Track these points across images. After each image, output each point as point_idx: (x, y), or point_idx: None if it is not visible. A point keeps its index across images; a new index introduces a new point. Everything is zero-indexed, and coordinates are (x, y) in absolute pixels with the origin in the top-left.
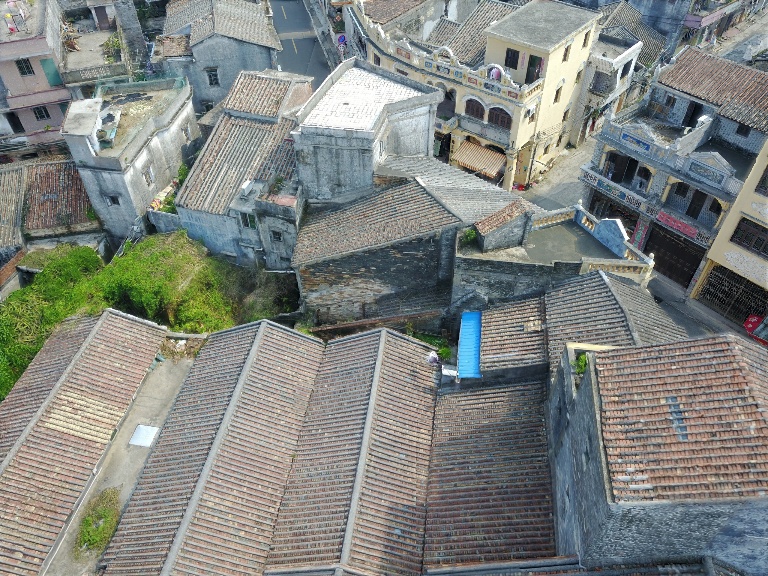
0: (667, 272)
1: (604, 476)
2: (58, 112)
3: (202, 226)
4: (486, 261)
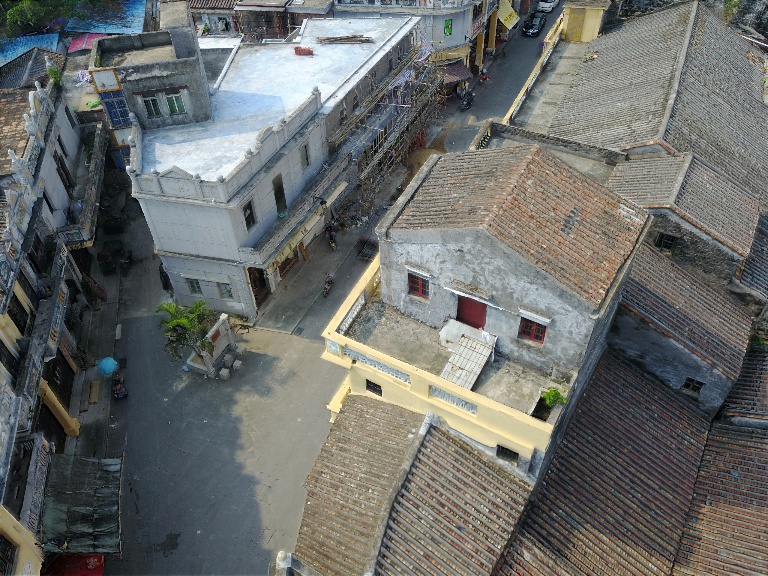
0: None
1: None
2: None
3: None
4: None
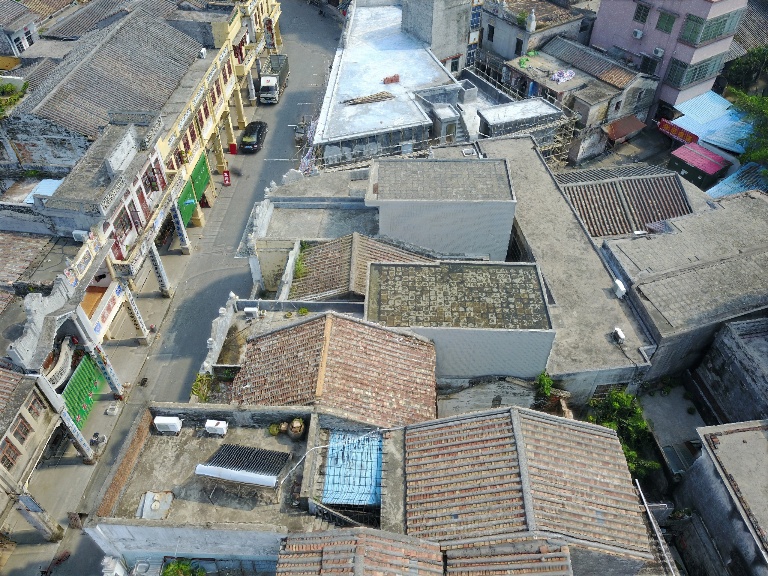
0: (336, 5)
1: None
2: None
3: None
4: None
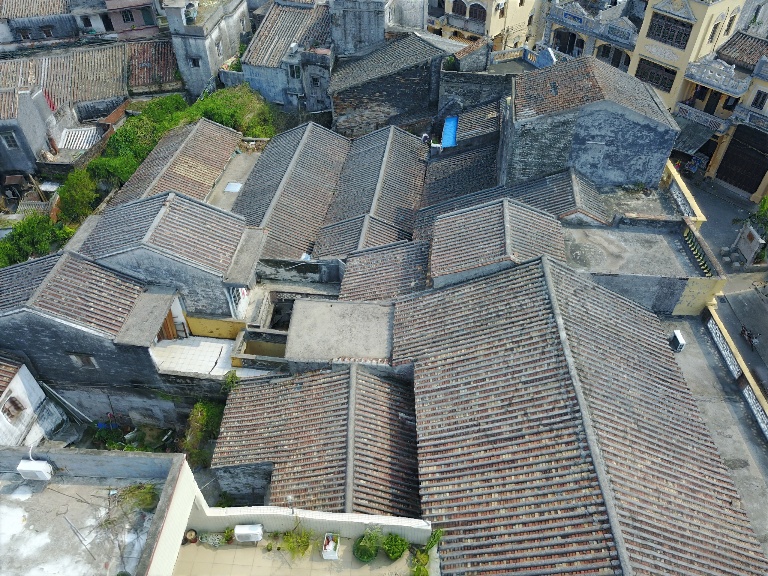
0: None
1: (513, 114)
2: (140, 17)
3: (260, 80)
4: (461, 74)
